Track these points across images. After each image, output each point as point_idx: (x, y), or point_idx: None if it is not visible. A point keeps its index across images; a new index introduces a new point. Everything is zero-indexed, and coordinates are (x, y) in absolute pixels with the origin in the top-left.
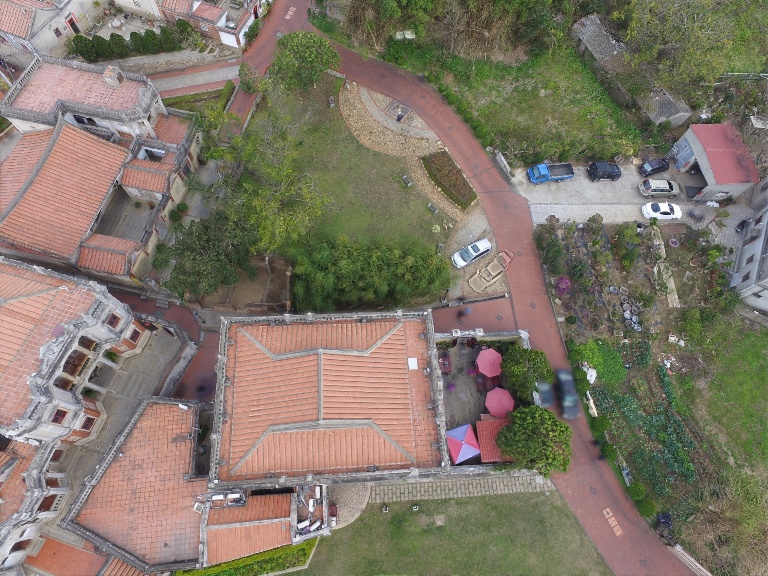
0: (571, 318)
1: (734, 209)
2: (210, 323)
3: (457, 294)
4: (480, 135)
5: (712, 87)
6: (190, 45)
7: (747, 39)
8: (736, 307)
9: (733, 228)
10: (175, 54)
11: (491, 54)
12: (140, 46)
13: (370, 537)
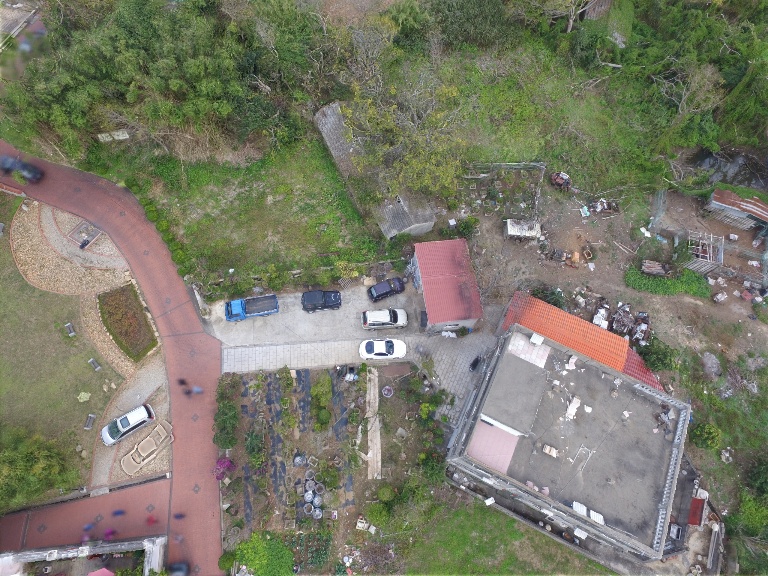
0: (227, 511)
1: (475, 339)
2: None
3: (102, 480)
4: (176, 262)
5: (476, 180)
6: None
7: (527, 117)
8: (443, 479)
9: (468, 365)
10: None
11: (217, 153)
12: None
13: None
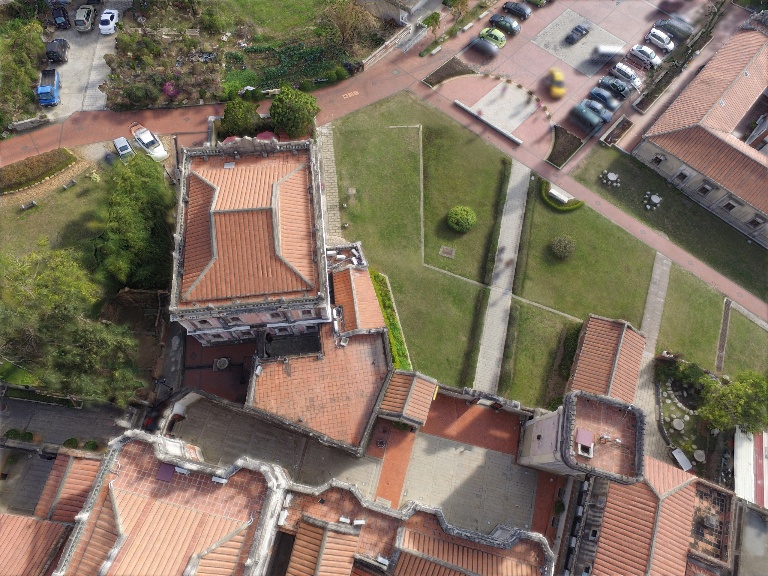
0: (201, 91)
1: None
2: (173, 384)
3: (168, 171)
4: None
5: None
6: None
7: None
8: None
9: None
10: None
11: None
12: None
13: (365, 236)
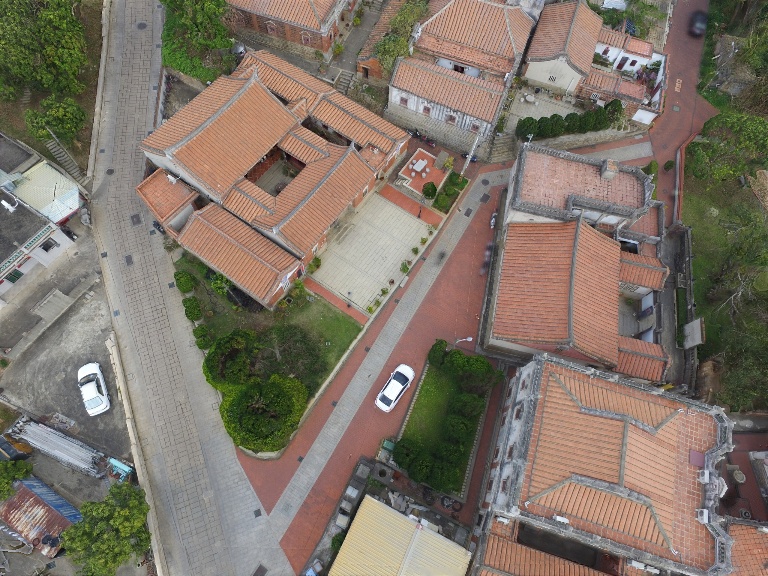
0: None
1: None
2: None
3: None
4: None
5: None
6: None
7: None
8: None
9: None
10: (598, 132)
11: None
12: (577, 126)
13: None
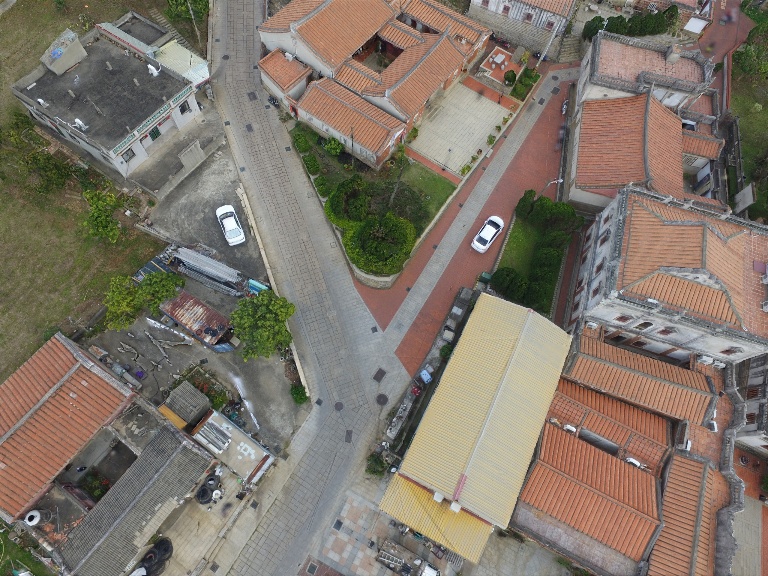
0: None
1: None
2: None
3: None
4: None
5: None
6: (671, 29)
7: None
8: None
9: None
10: (655, 37)
11: None
12: (639, 28)
13: None
